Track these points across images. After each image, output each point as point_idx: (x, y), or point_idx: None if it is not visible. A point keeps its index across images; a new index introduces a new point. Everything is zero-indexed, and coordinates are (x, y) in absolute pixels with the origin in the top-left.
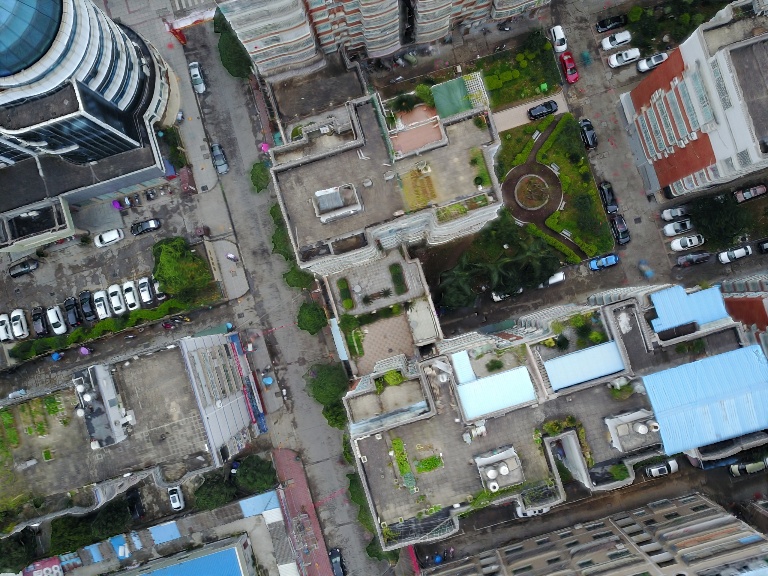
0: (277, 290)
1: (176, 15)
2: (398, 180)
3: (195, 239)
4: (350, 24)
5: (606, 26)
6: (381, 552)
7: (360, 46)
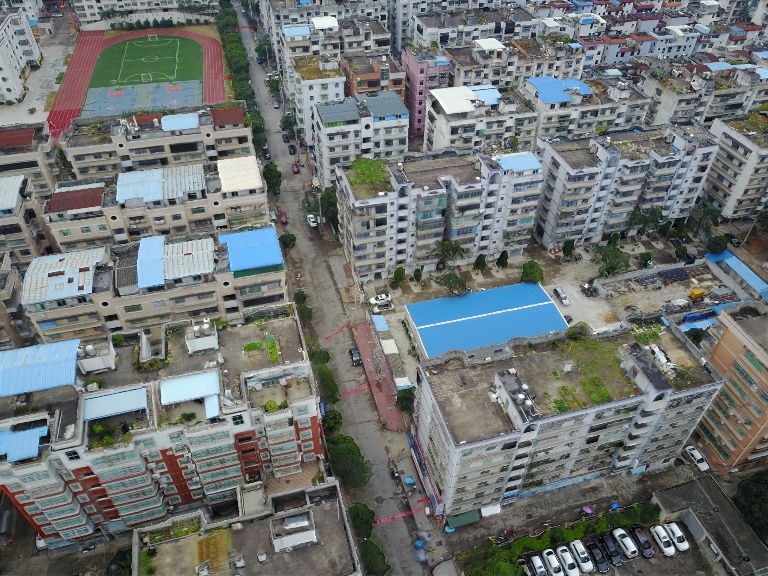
0: (403, 569)
1: None
2: None
3: None
4: None
5: None
6: (317, 352)
7: None
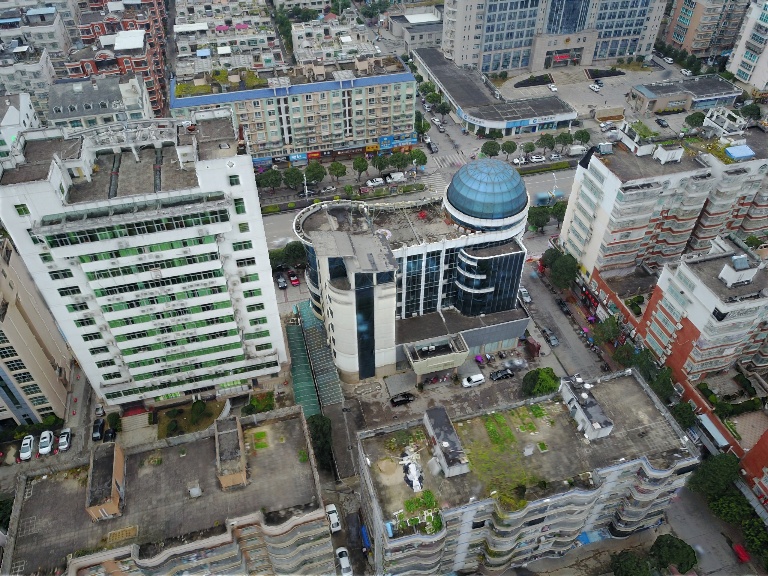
0: None
1: None
2: (767, 270)
3: None
4: (659, 241)
5: None
6: None
7: (652, 266)
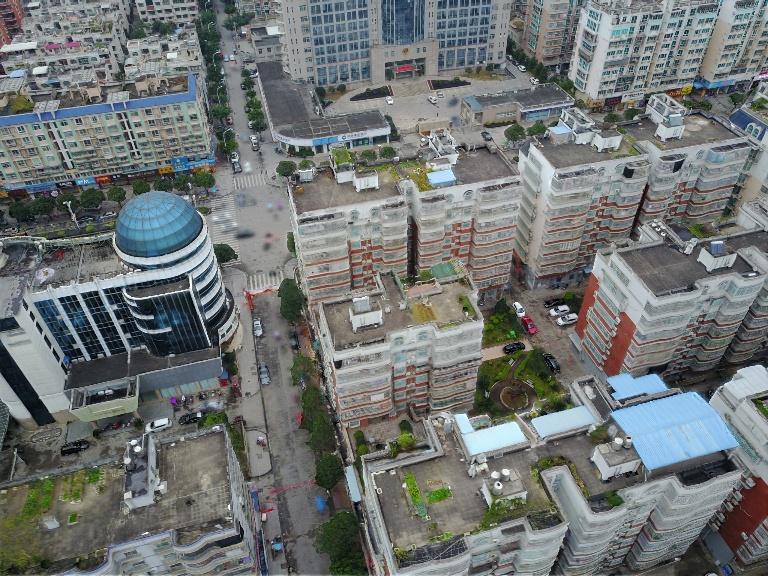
0: (296, 470)
1: None
2: (409, 310)
3: None
4: (375, 272)
5: (551, 304)
6: None
7: None
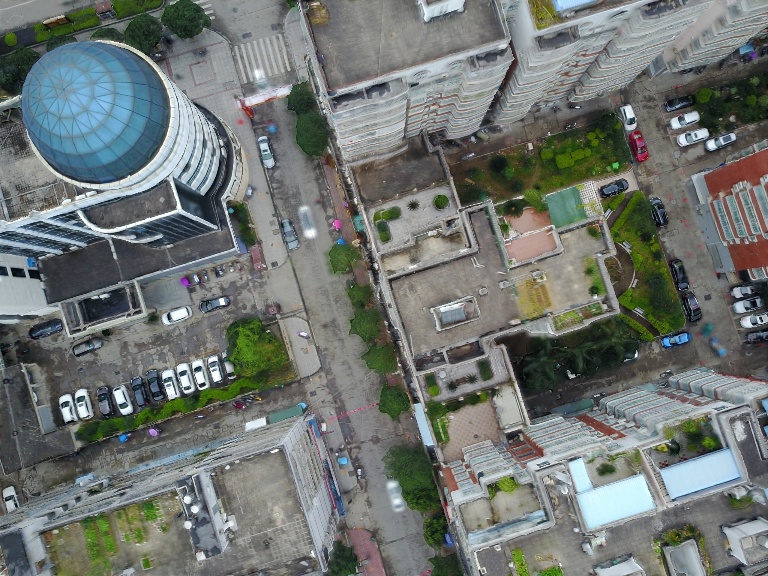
0: (349, 367)
1: (243, 88)
2: (513, 288)
3: (265, 316)
4: (440, 114)
5: (675, 106)
6: None
7: (441, 129)
